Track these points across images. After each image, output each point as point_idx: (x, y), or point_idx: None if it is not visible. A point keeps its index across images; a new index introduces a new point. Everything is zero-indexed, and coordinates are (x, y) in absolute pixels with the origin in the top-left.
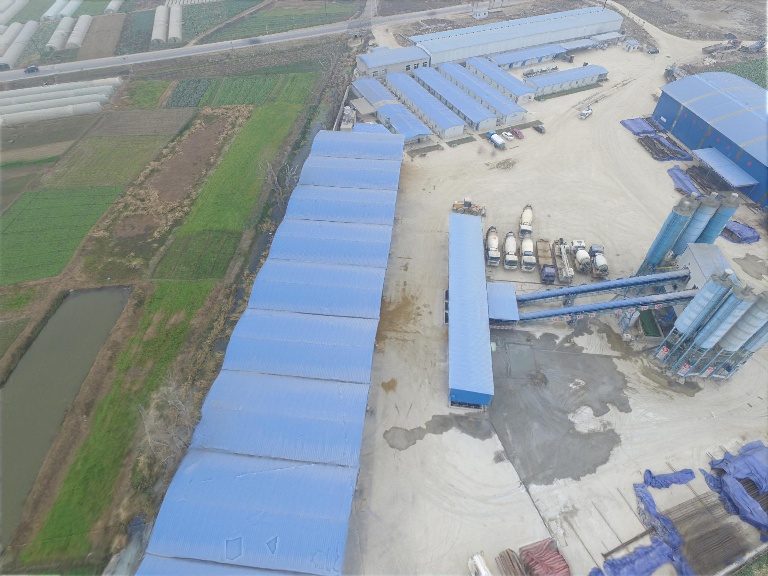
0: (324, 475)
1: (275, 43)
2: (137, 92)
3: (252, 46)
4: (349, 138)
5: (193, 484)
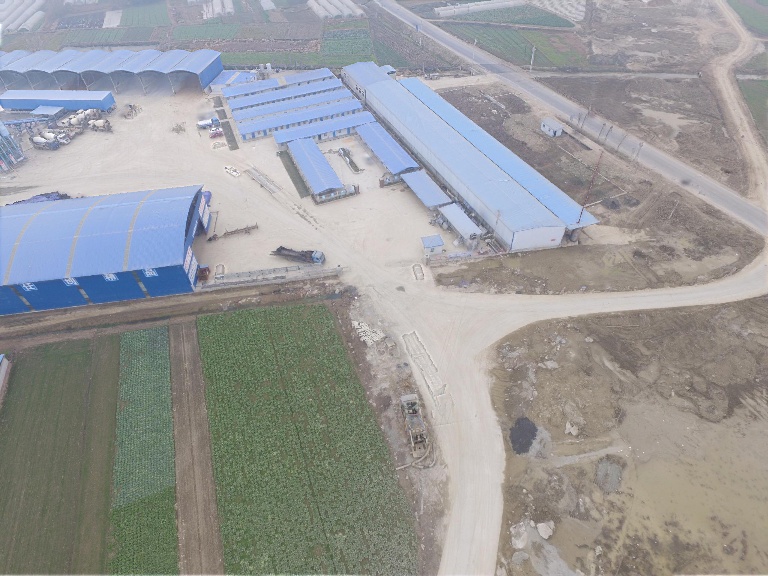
0: None
1: (436, 42)
2: (349, 22)
3: (427, 36)
4: (198, 57)
5: (17, 52)
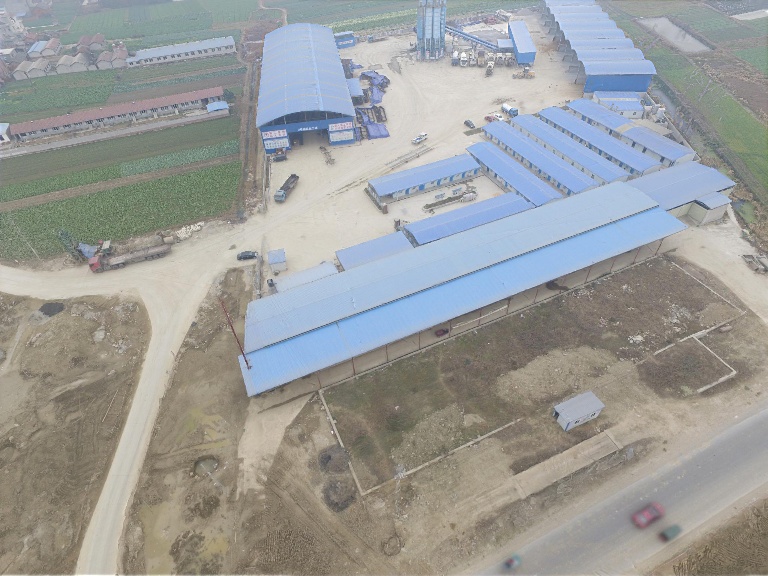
0: (555, 4)
1: None
2: None
3: None
4: (626, 63)
5: (589, 0)
